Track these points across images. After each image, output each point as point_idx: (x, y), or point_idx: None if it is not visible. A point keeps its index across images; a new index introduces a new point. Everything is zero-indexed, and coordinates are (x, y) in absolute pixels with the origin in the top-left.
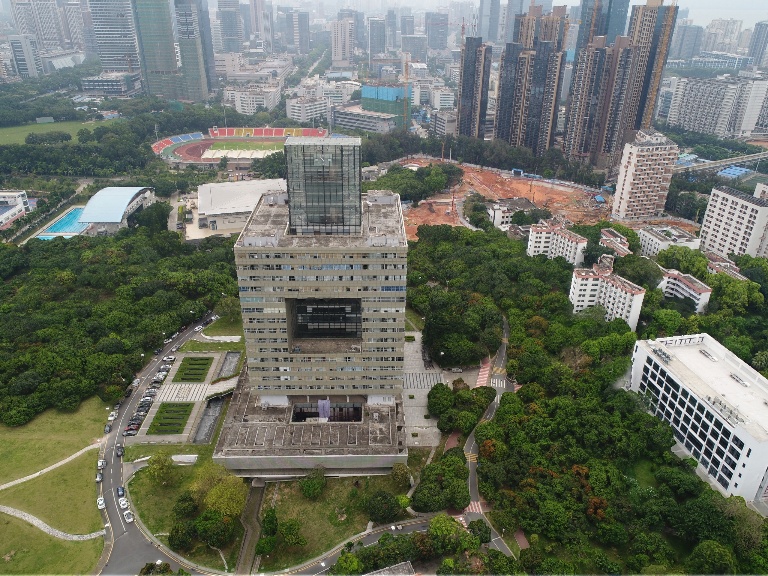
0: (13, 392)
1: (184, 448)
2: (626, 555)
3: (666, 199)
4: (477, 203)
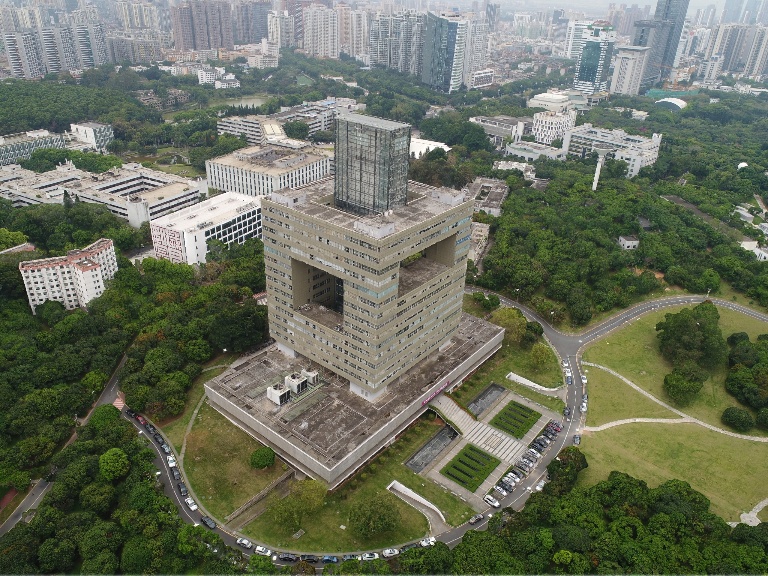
0: None
1: (514, 387)
2: None
3: None
4: None
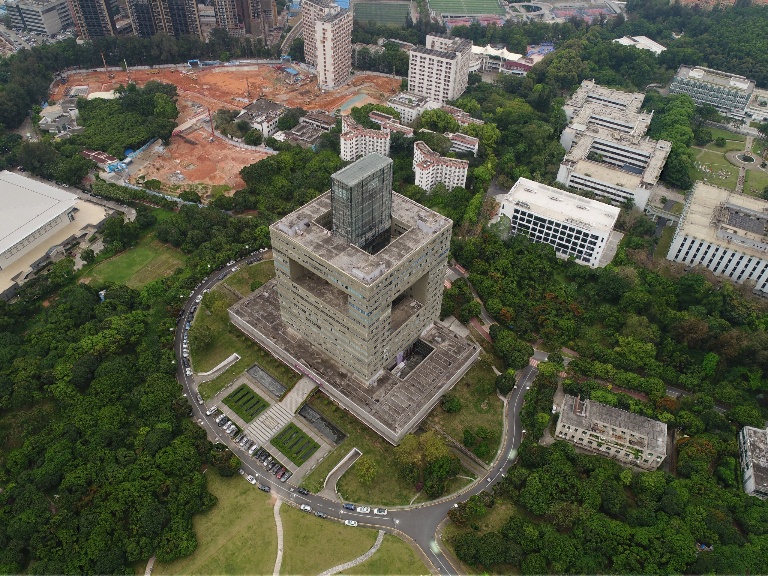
0: (153, 535)
1: (339, 452)
2: (596, 323)
3: (352, 59)
4: (238, 122)
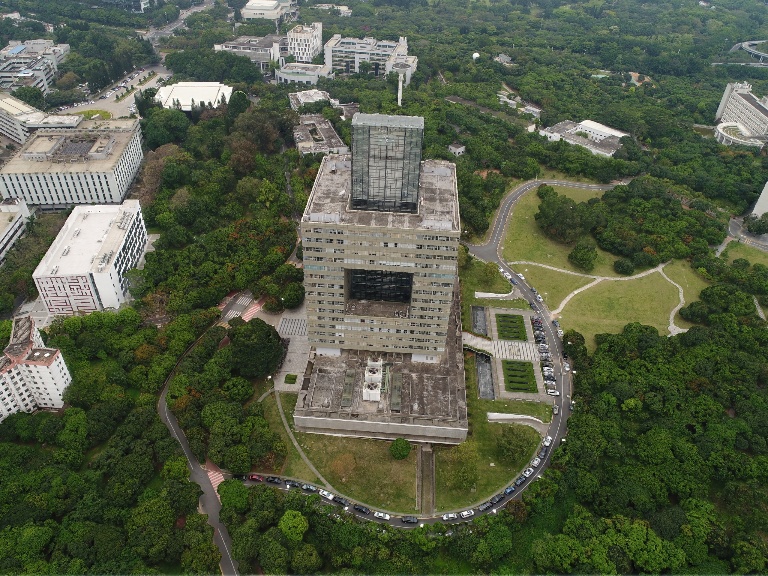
0: None
1: (488, 303)
2: None
3: None
4: None
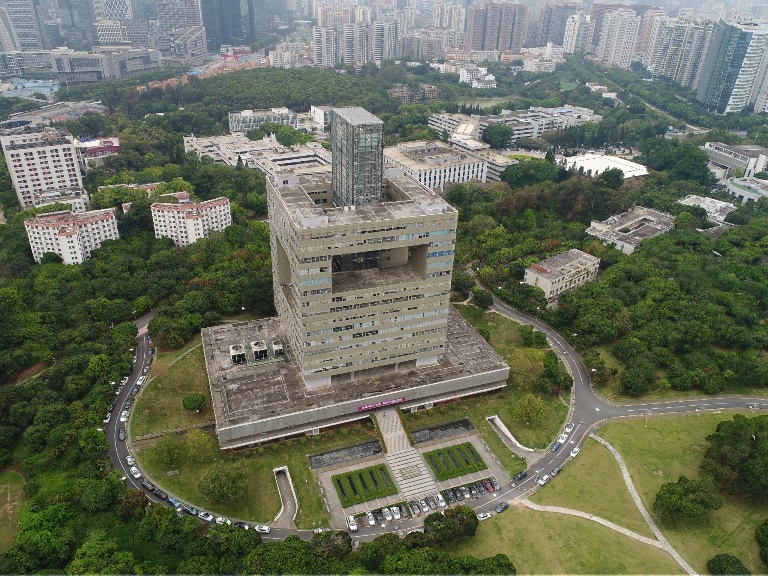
0: None
1: (484, 431)
2: None
3: None
4: None
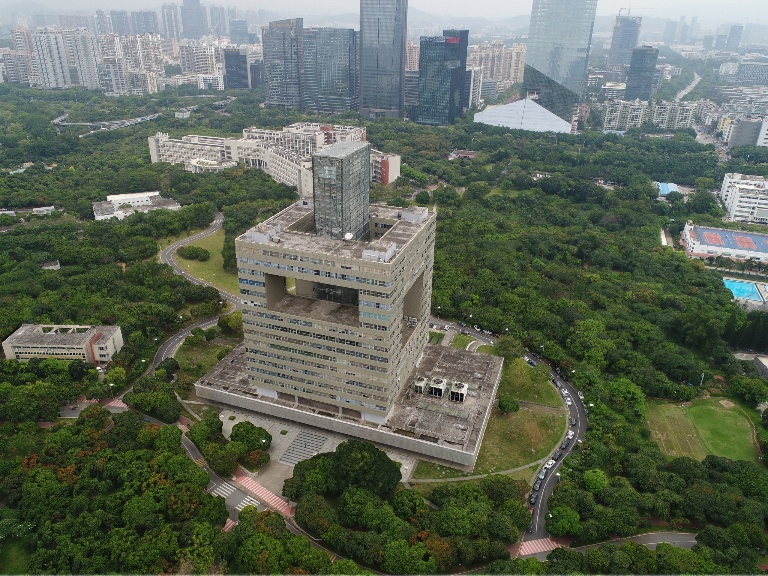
0: None
1: None
2: None
3: None
4: None
